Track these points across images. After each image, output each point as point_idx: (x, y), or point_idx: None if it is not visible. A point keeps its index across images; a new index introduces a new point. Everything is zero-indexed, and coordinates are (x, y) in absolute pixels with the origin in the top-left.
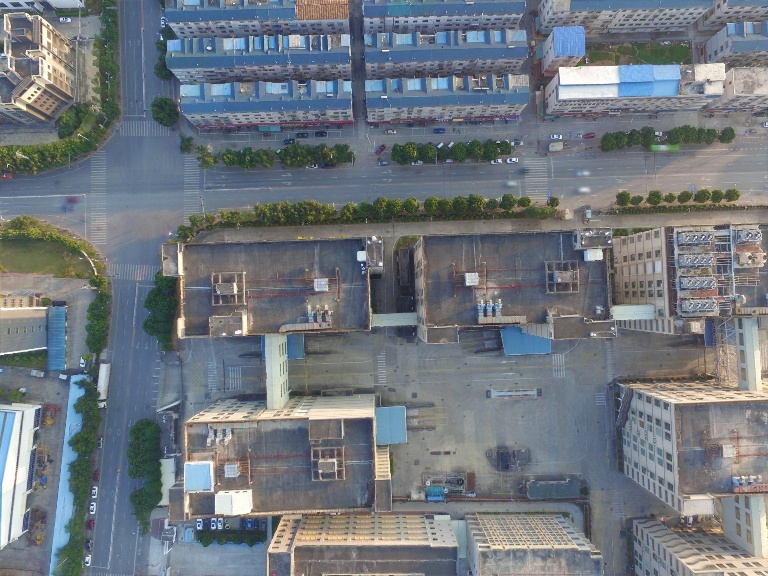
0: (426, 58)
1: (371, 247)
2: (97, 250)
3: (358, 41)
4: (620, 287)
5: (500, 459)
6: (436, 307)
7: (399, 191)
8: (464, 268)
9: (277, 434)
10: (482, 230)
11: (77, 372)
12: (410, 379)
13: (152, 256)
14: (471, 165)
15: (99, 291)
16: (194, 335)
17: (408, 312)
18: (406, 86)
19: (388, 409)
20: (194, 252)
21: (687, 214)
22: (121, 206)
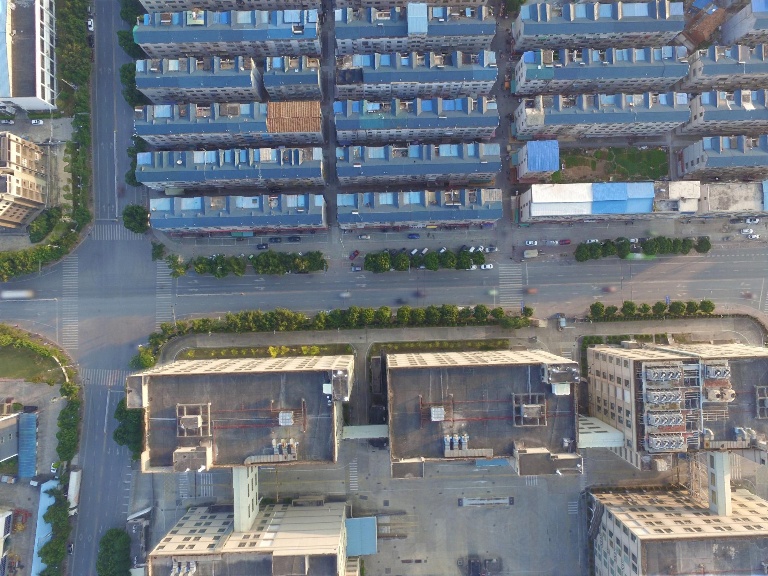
0: (398, 172)
1: (337, 380)
2: (69, 355)
3: (332, 144)
4: (593, 399)
5: (471, 569)
6: (402, 439)
7: (372, 297)
8: (431, 400)
9: (242, 566)
10: (456, 337)
11: (48, 478)
12: (382, 487)
13: (124, 361)
14: (445, 271)
15: (70, 397)
16: (159, 466)
17: (379, 424)
18: (378, 201)
19: (359, 520)
20: (159, 382)
21: (662, 321)
22: (93, 310)
